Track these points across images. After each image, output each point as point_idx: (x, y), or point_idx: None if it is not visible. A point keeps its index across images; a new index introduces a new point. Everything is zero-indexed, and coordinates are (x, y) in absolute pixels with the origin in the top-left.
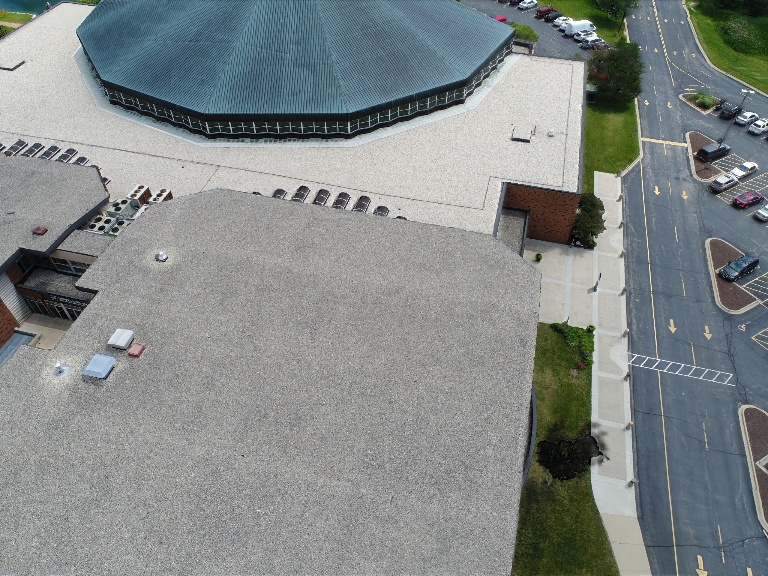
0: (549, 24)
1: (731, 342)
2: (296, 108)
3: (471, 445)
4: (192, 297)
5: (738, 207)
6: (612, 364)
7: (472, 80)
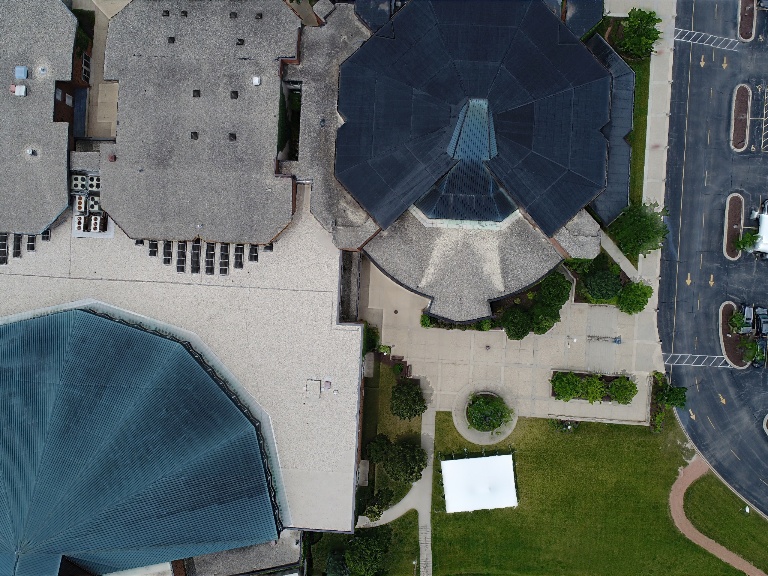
0: None
1: None
2: (10, 328)
3: None
4: (4, 128)
5: None
6: None
7: None
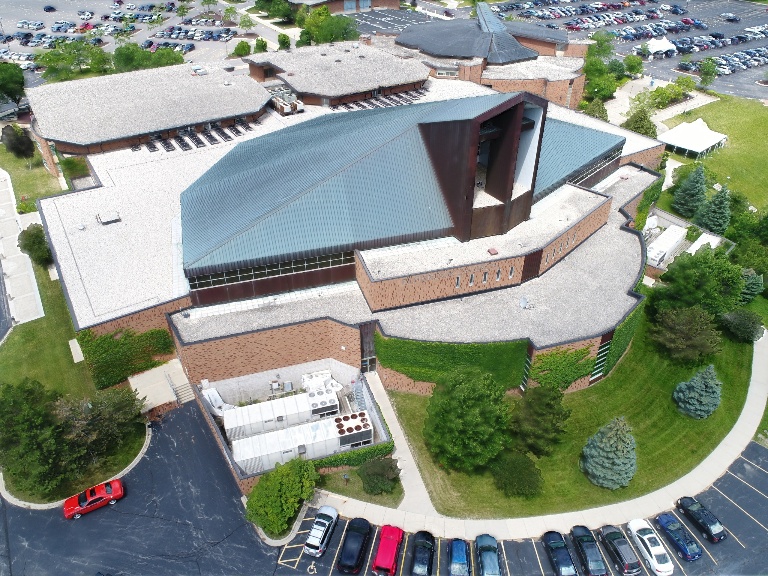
0: None
1: None
2: (275, 131)
3: None
4: None
5: None
6: (4, 208)
7: None
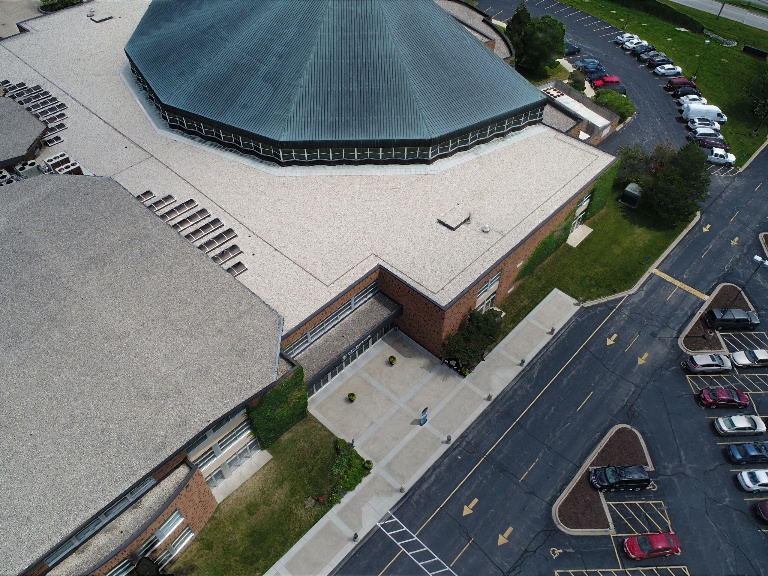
0: (674, 100)
1: (523, 562)
2: (237, 121)
3: (2, 525)
4: None
5: (701, 402)
6: (357, 515)
7: (447, 142)
